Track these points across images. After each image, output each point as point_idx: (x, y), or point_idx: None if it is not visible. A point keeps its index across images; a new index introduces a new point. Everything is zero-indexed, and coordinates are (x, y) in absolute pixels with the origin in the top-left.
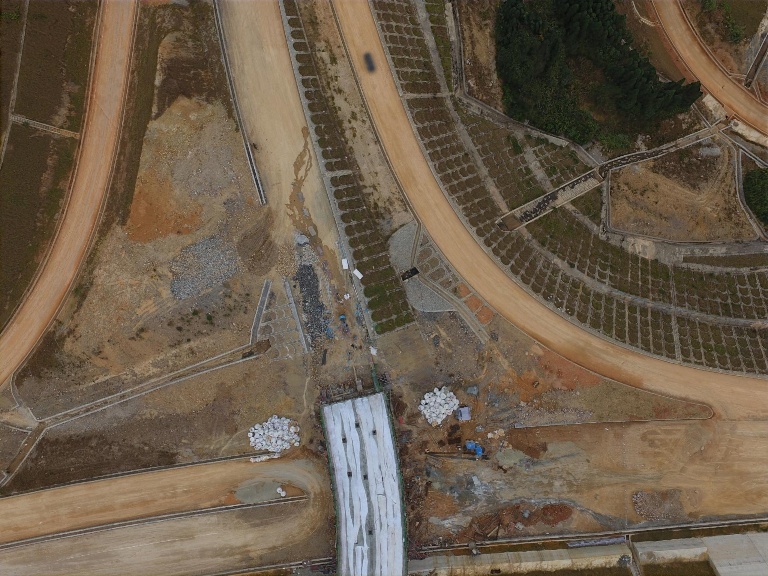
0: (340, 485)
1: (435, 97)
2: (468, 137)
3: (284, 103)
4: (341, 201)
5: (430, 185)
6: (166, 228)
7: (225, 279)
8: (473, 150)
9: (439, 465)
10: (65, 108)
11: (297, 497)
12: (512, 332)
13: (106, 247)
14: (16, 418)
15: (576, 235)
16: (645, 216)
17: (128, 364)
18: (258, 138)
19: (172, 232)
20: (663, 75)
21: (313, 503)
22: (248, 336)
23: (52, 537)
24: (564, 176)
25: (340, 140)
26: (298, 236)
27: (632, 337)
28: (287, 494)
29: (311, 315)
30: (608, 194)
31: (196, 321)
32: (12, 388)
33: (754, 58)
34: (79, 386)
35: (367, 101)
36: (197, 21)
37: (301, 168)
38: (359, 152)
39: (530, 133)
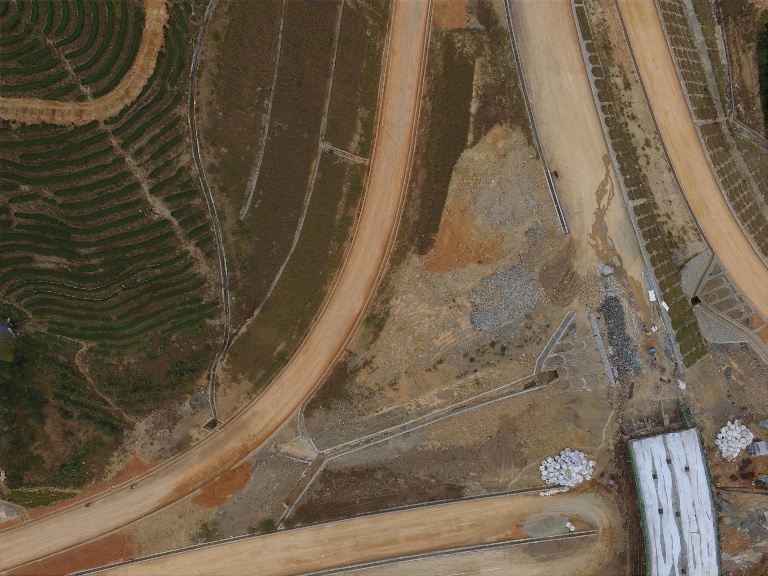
0: (650, 522)
1: (716, 122)
2: (744, 163)
3: (584, 130)
4: (643, 231)
5: (723, 214)
6: (466, 258)
7: (527, 310)
8: (749, 176)
9: (733, 500)
10: (358, 134)
11: (586, 532)
12: None
13: (402, 276)
14: (296, 449)
15: None
16: None
17: (413, 395)
18: (558, 166)
19: (472, 262)
20: None
21: (601, 538)
22: (533, 366)
23: (336, 571)
24: None
25: (634, 167)
26: (603, 267)
27: None
28: (575, 528)
29: (617, 348)
30: None
31: (489, 352)
32: (299, 419)
33: None
34: (362, 417)
35: (660, 127)
36: (493, 46)
37: (603, 197)
38: (653, 180)
39: None
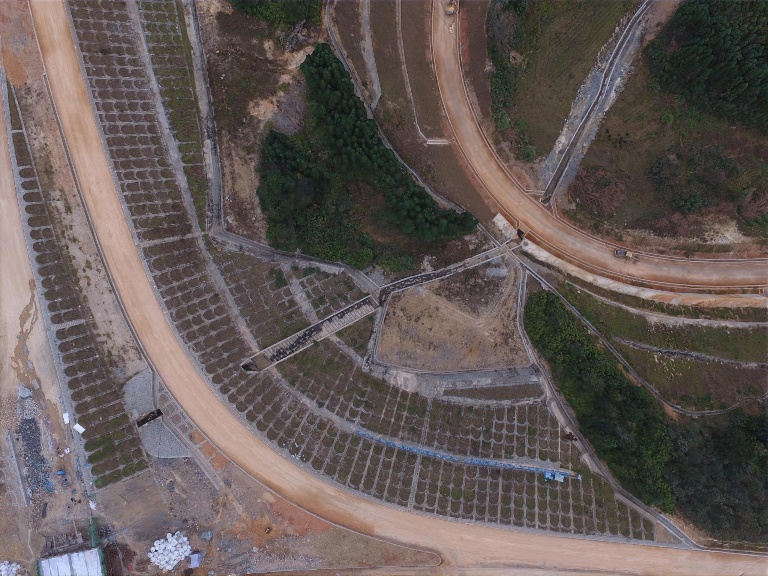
0: None
1: (182, 239)
2: (220, 277)
3: (12, 255)
4: (67, 354)
5: (166, 333)
6: None
7: None
8: (224, 290)
9: None
10: None
11: None
12: (244, 480)
13: None
14: None
15: (335, 370)
16: (410, 347)
17: None
18: None
19: None
20: (447, 199)
21: None
22: None
23: None
24: (334, 305)
25: (74, 289)
26: (21, 390)
27: (367, 483)
28: None
29: (32, 468)
30: (382, 321)
31: None
32: None
33: (553, 174)
34: None
35: (103, 249)
36: None
37: (27, 321)
38: (93, 301)
39: (298, 264)
